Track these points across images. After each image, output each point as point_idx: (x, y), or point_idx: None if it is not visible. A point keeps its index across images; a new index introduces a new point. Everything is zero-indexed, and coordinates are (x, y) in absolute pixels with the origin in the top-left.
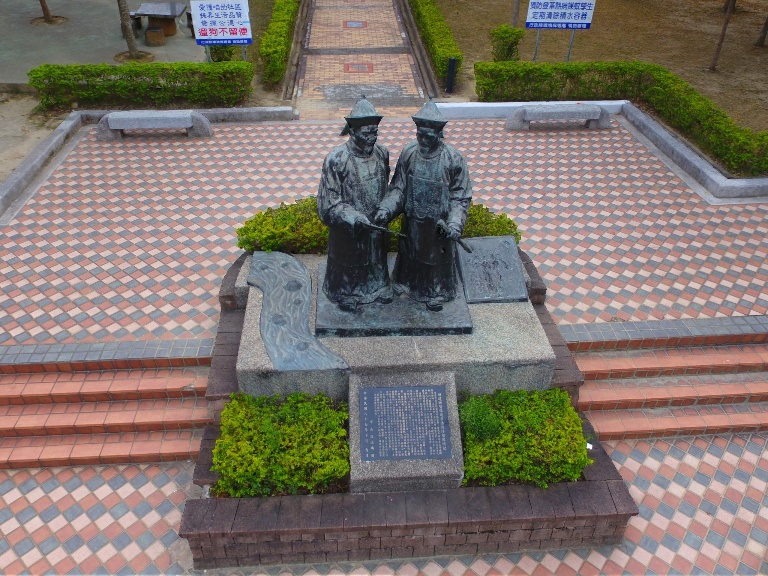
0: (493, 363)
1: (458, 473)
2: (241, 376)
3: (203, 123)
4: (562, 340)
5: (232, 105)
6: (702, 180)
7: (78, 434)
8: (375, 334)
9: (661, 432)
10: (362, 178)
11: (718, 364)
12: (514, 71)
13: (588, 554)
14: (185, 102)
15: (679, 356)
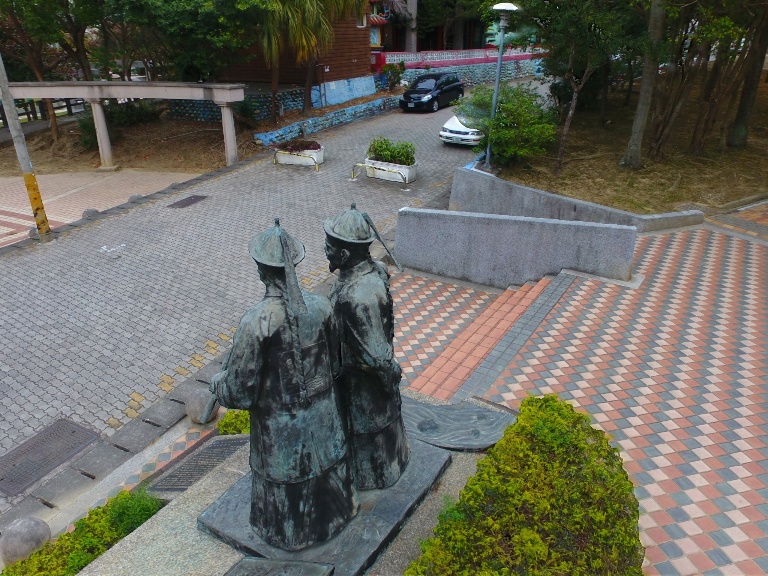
0: None
1: None
2: None
3: None
4: None
5: None
6: None
7: None
8: None
9: None
10: None
11: None
12: None
13: None
14: None
15: None
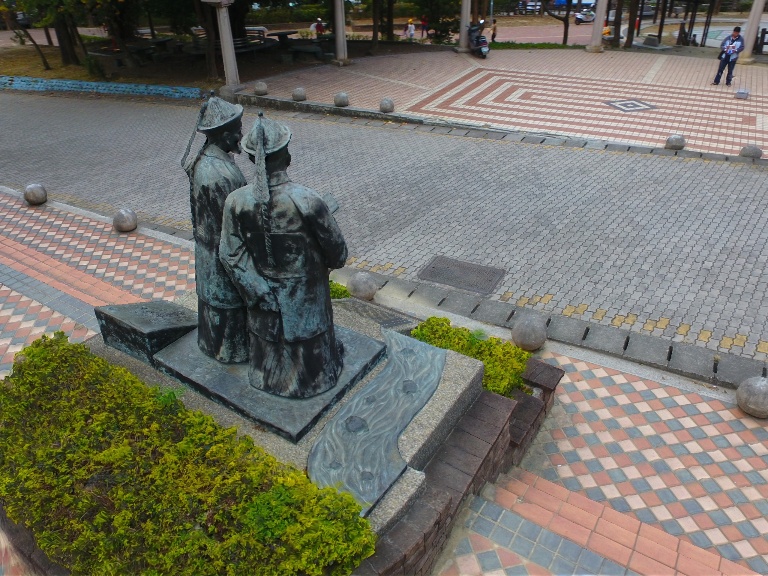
0: None
1: None
2: None
3: None
4: None
5: None
6: None
7: None
8: None
9: None
10: None
11: None
12: None
13: None
14: None
15: None
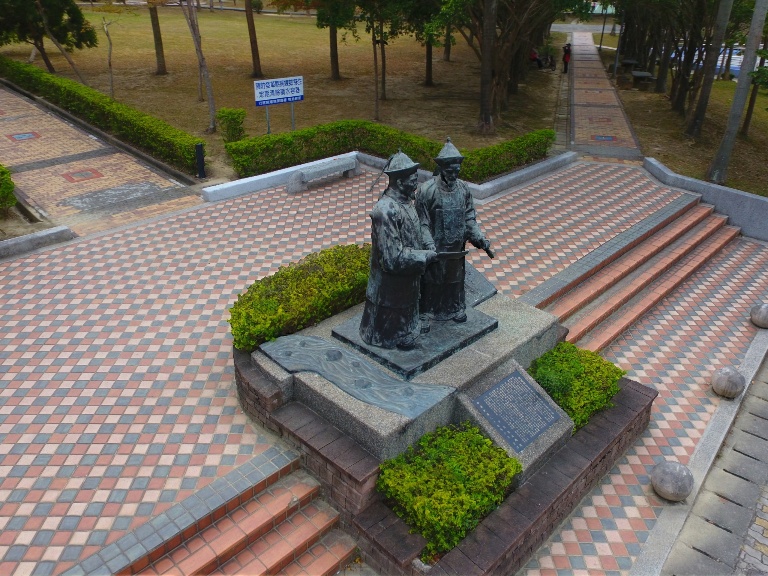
0: (531, 339)
1: (572, 425)
2: (387, 441)
3: None
4: None
5: None
6: None
7: None
8: (445, 357)
9: None
10: (413, 221)
11: (590, 295)
12: (265, 144)
13: (643, 441)
14: None
15: (570, 300)
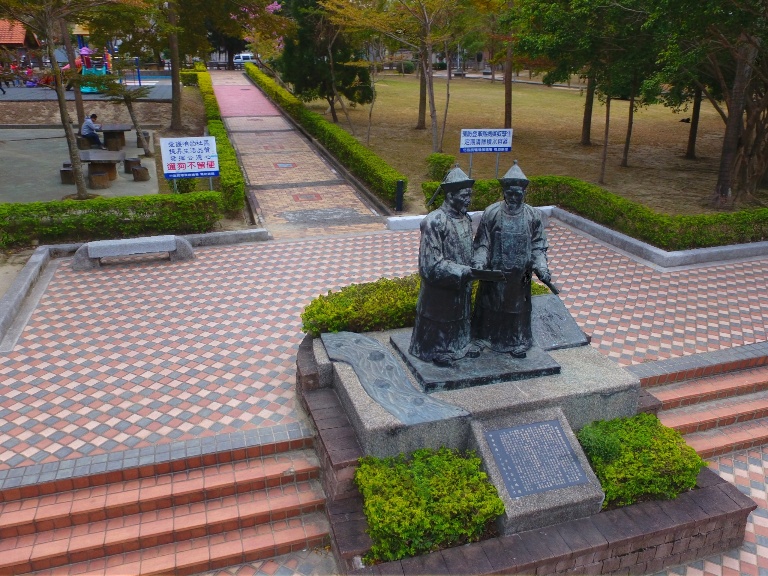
0: (592, 393)
1: (600, 495)
2: (370, 436)
3: (186, 246)
4: None
5: (203, 232)
6: (646, 256)
7: (175, 542)
8: (479, 383)
9: (721, 449)
10: (460, 236)
11: (741, 385)
12: None
13: (721, 560)
14: (154, 232)
15: (708, 384)
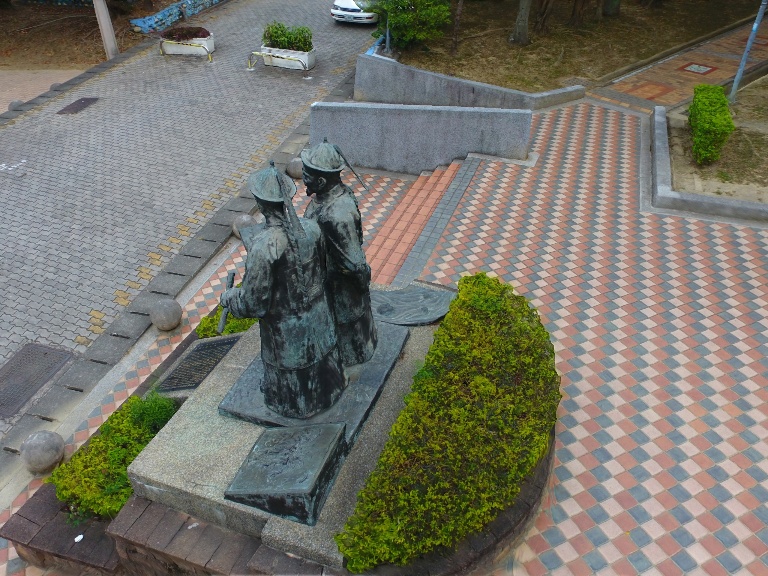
0: None
1: None
2: None
3: None
4: (175, 551)
5: None
6: None
7: None
8: None
9: None
10: None
11: None
12: None
13: None
14: None
15: None
